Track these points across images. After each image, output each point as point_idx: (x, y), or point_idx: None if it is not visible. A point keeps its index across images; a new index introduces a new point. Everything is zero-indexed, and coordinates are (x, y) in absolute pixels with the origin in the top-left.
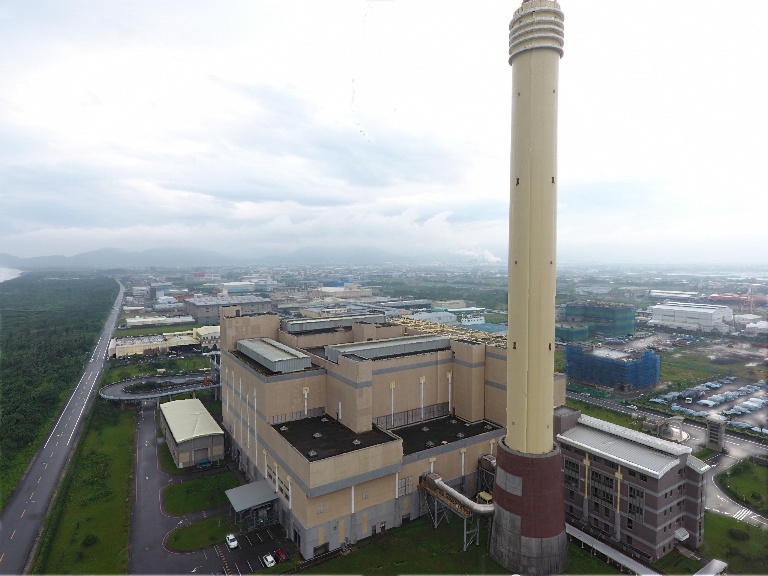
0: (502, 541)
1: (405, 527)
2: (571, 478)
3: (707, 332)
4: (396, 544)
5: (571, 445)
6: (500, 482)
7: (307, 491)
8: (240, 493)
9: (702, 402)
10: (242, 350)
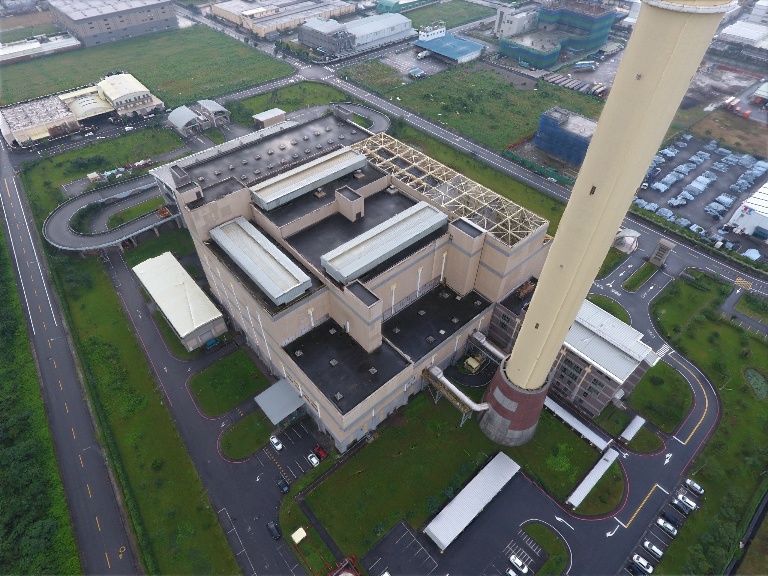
0: (492, 428)
1: (411, 404)
2: None
3: None
4: (407, 425)
5: None
6: (498, 398)
7: (340, 427)
8: (269, 400)
9: (656, 187)
10: (221, 247)
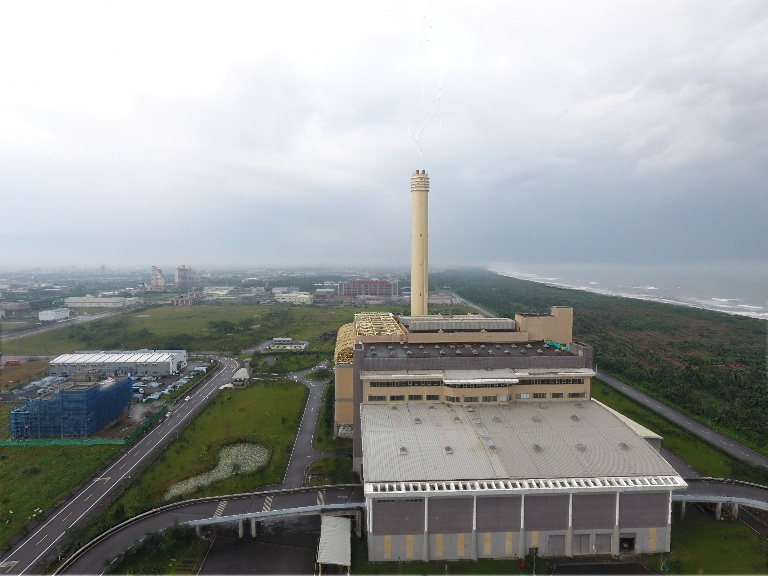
0: None
1: None
2: None
3: None
4: None
5: None
6: None
7: None
8: None
9: None
10: None
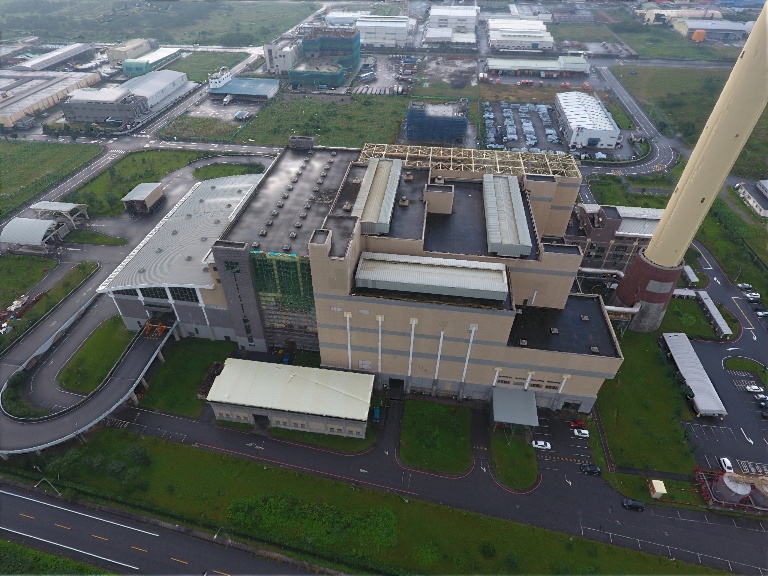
0: (647, 320)
1: None
2: (618, 256)
3: (406, 48)
4: None
5: (628, 236)
6: (654, 289)
7: (609, 376)
8: (507, 412)
9: (511, 138)
10: (382, 287)
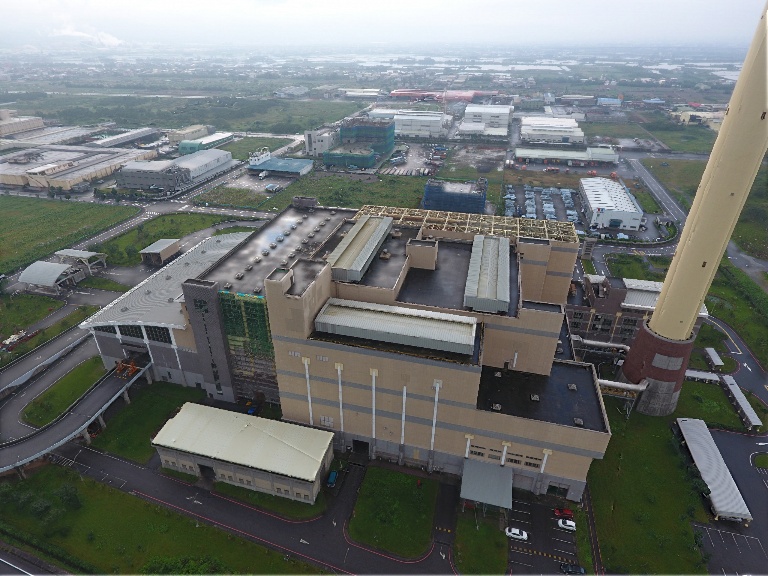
0: (657, 401)
1: None
2: (627, 330)
3: (439, 138)
4: None
5: (635, 309)
6: (661, 365)
7: (597, 456)
8: (477, 488)
9: (529, 216)
10: (341, 332)
